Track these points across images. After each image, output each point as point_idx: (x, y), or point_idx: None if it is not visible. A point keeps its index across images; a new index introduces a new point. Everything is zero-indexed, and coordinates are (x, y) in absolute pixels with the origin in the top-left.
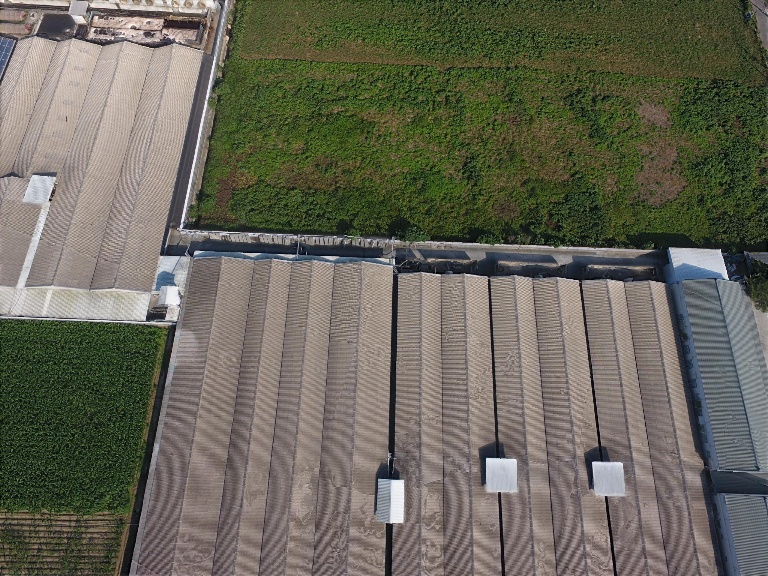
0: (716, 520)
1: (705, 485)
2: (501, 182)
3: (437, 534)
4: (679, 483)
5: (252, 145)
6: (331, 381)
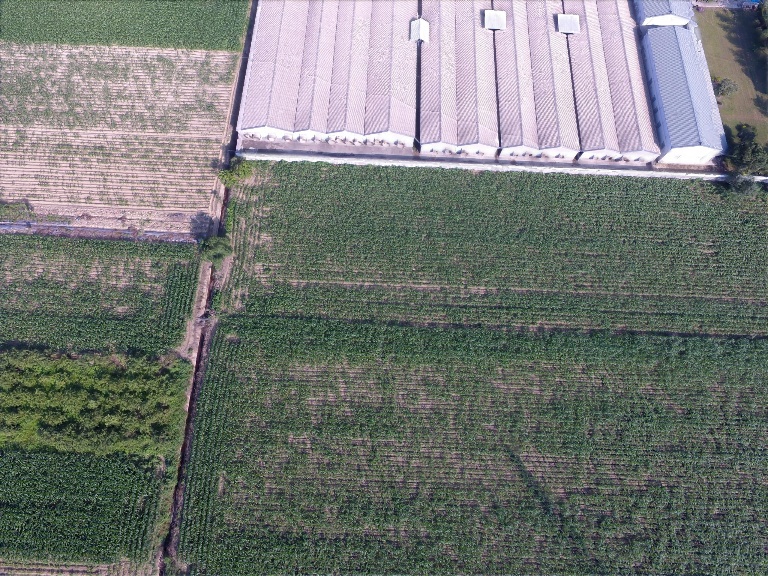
0: (643, 55)
1: (636, 34)
2: None
3: (451, 51)
4: (617, 28)
5: None
6: None
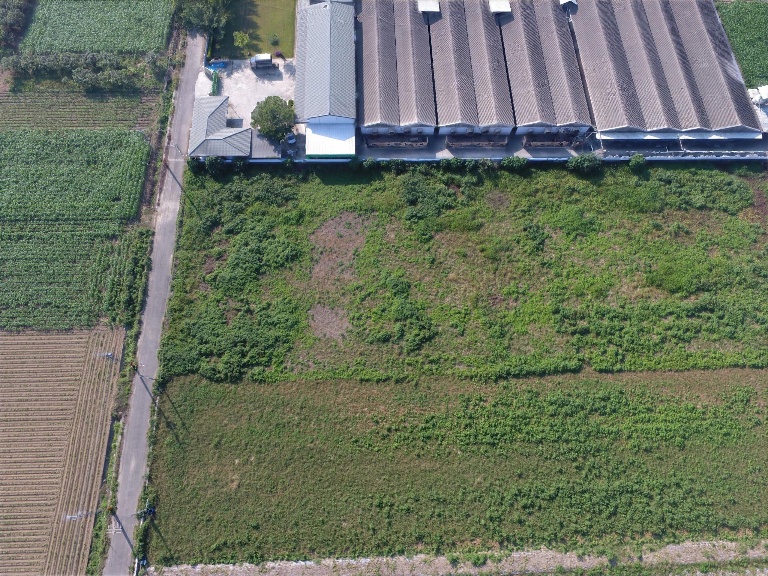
0: None
1: (359, 8)
2: (504, 227)
3: None
4: (380, 5)
5: (760, 252)
6: (623, 54)
